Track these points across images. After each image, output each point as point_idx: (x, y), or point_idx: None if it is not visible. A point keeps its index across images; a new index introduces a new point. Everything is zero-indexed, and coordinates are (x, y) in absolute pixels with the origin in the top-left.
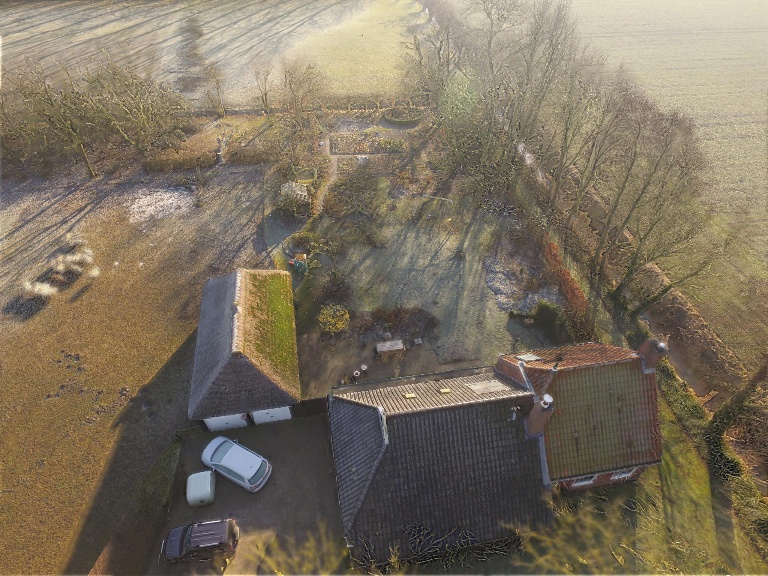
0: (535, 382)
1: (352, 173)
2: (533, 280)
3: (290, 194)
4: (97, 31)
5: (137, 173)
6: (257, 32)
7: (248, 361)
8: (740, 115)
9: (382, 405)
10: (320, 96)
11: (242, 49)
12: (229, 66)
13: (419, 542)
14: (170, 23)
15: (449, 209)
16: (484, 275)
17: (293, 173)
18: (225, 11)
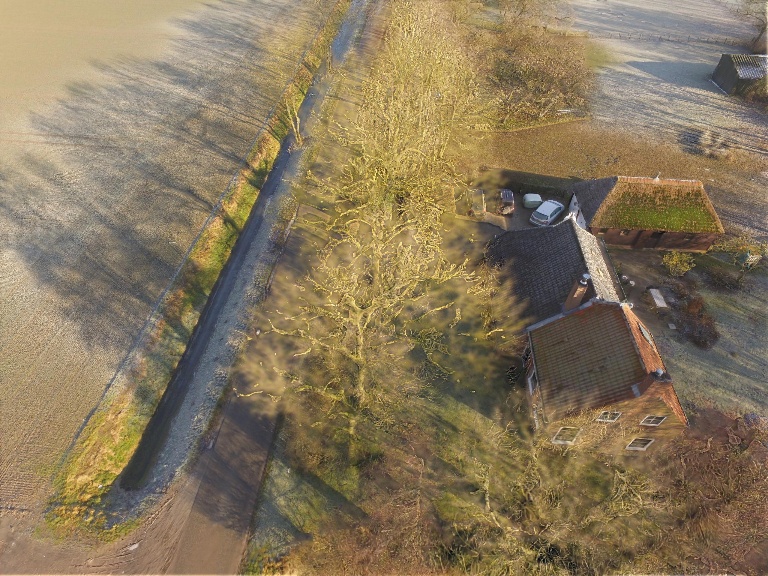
0: None
1: None
2: None
3: None
4: None
5: None
6: None
7: (613, 186)
8: None
9: None
10: None
11: None
12: None
13: None
14: None
15: None
16: None
17: None
18: None
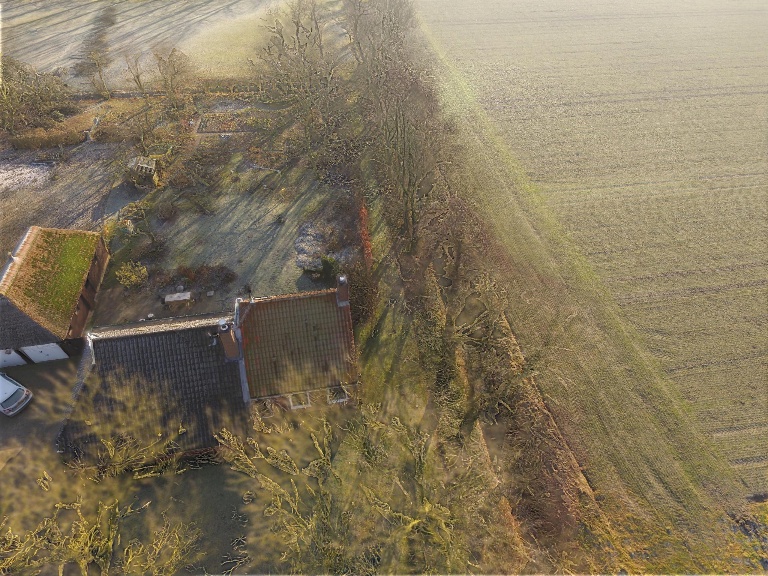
0: (241, 314)
1: (193, 147)
2: (333, 240)
3: (123, 165)
4: (14, 20)
5: (6, 150)
6: (169, 20)
7: (10, 302)
8: (606, 94)
9: (107, 335)
10: (188, 78)
11: (148, 36)
12: (130, 52)
13: (126, 450)
14: (88, 12)
15: (288, 181)
16: (295, 237)
17: (145, 148)
18: (146, 1)
